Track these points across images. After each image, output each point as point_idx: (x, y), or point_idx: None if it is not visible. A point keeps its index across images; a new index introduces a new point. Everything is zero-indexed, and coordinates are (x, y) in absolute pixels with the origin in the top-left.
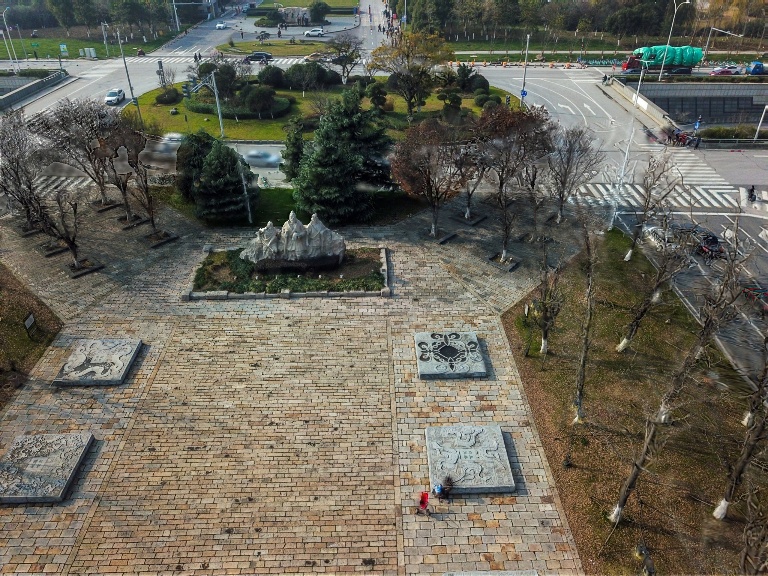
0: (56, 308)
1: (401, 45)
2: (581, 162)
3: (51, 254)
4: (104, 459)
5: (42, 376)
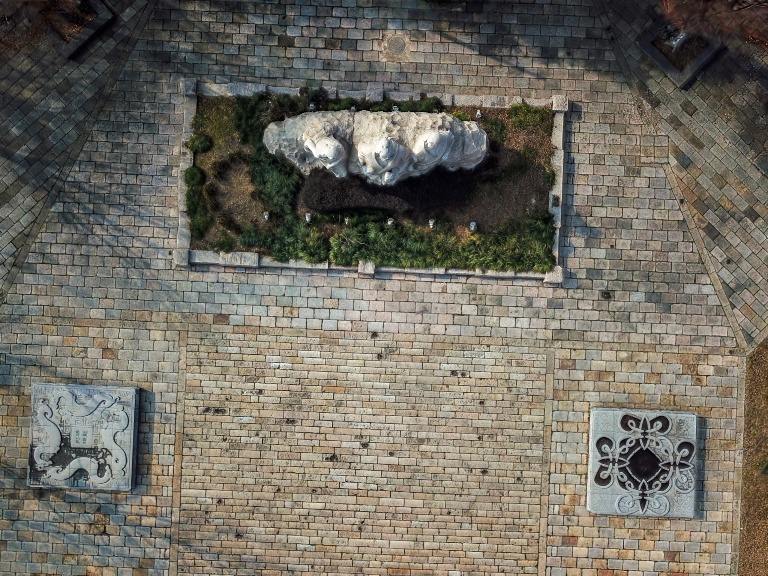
0: None
1: None
2: None
3: None
4: None
5: (6, 459)
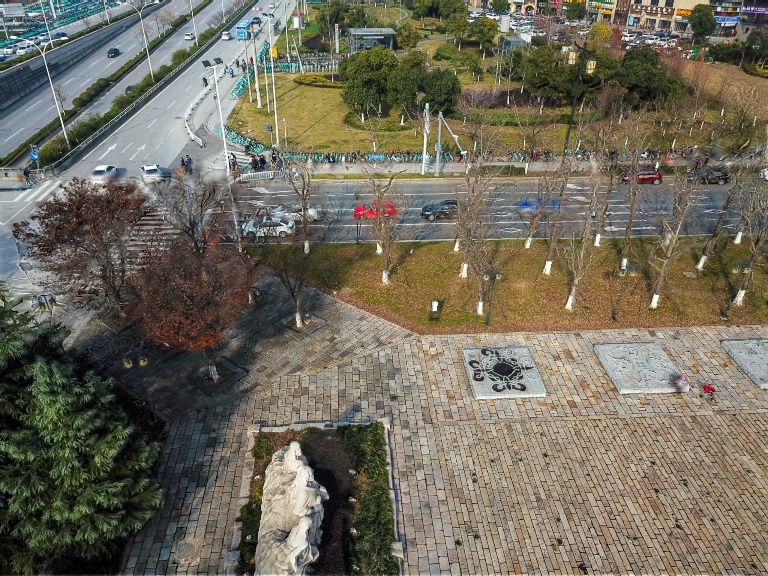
0: None
1: None
2: None
3: None
4: None
5: None
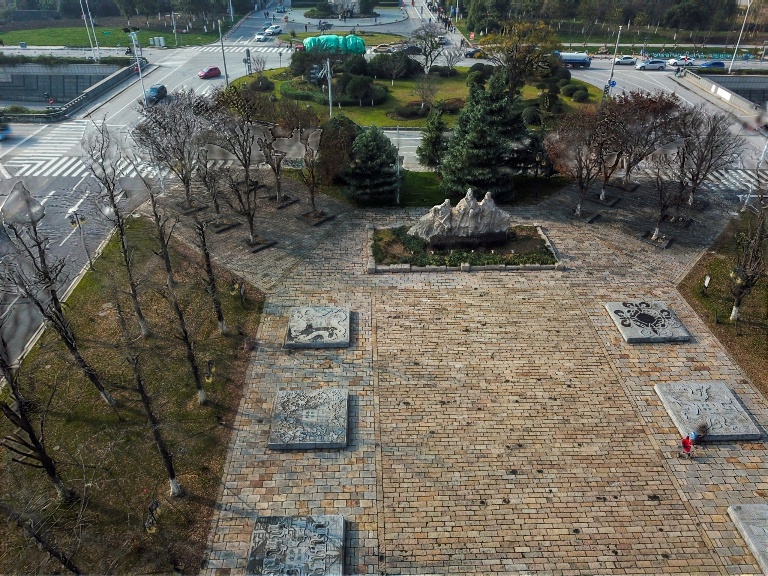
0: (251, 279)
1: (511, 35)
2: (716, 146)
3: (221, 231)
4: (366, 411)
5: (270, 340)
